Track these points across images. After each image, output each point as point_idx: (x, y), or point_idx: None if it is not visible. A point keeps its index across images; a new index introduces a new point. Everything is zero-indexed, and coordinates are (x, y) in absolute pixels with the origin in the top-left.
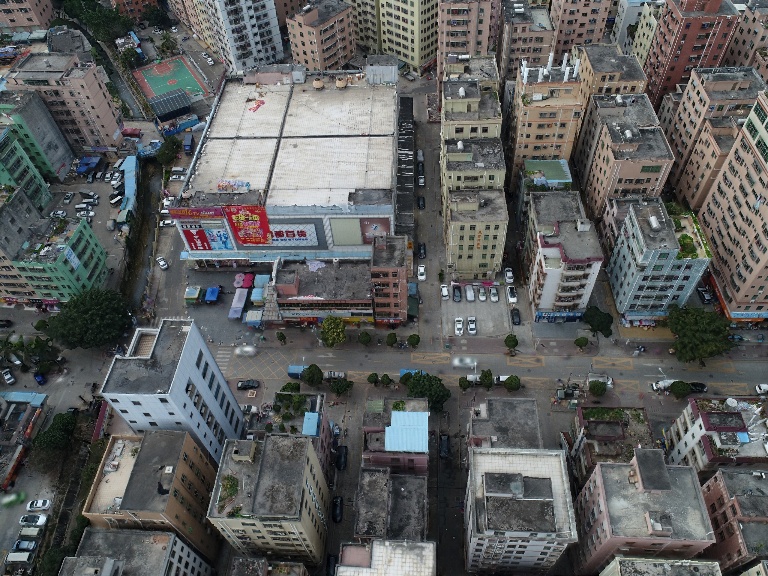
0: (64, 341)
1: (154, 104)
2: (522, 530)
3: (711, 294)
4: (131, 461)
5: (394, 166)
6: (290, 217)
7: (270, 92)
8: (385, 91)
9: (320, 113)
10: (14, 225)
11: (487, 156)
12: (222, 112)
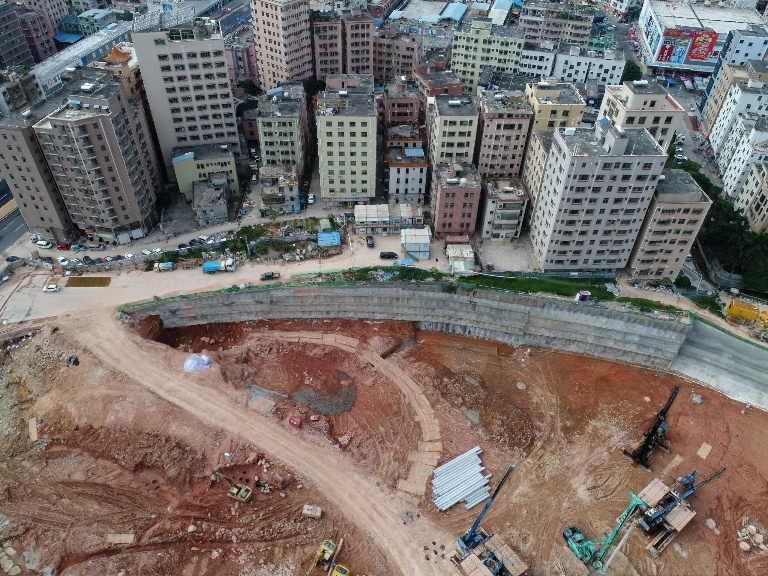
0: None
1: None
2: None
3: None
4: (739, 71)
5: None
6: None
7: (677, 4)
8: (748, 11)
9: (715, 14)
10: None
11: None
12: (655, 8)
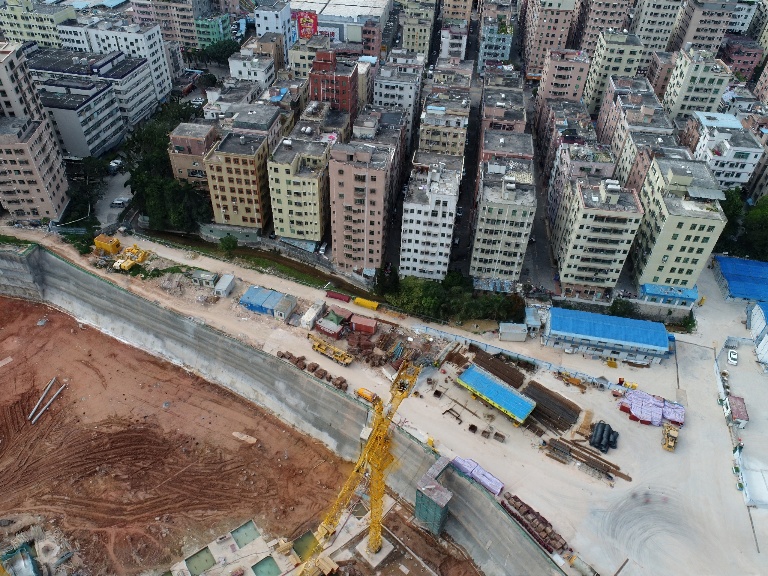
0: (213, 56)
1: (258, 1)
2: (403, 58)
3: (525, 77)
4: None
5: (382, 14)
6: (328, 22)
7: None
8: None
9: None
10: (199, 5)
11: (427, 8)
12: None
